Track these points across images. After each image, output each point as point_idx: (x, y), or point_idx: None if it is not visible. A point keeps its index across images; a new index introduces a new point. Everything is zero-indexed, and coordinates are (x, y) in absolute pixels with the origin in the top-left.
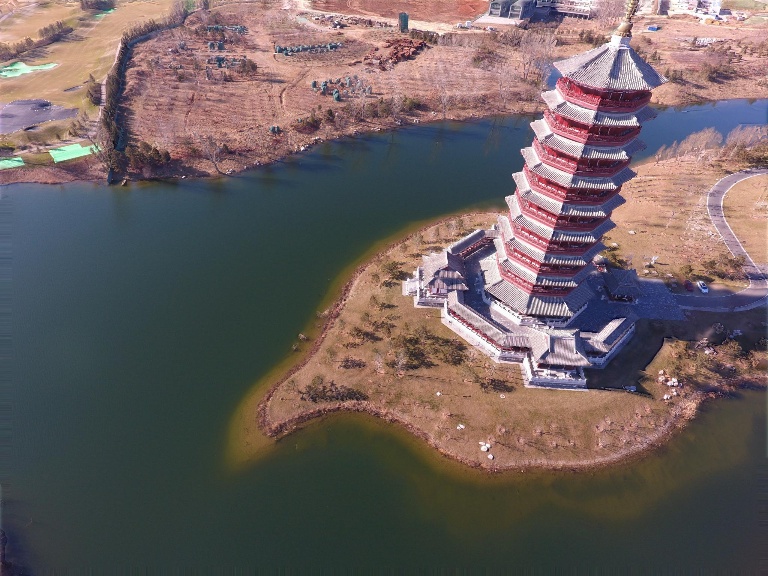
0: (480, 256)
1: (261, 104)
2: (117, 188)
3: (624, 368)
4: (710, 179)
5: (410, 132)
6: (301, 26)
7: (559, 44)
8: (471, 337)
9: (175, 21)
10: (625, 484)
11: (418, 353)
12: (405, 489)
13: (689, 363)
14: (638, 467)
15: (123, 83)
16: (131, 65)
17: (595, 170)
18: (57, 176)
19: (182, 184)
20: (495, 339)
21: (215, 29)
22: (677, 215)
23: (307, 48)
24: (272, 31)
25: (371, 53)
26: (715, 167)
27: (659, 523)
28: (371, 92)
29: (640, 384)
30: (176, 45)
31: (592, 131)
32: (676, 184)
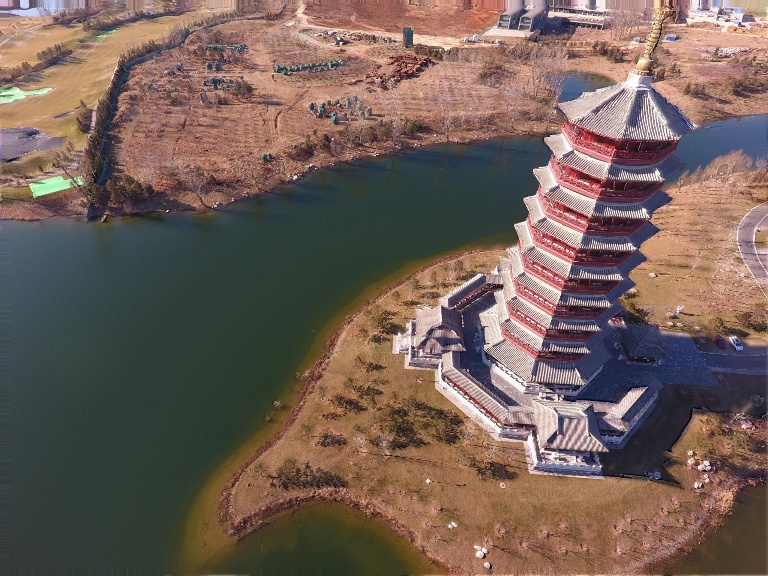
0: (481, 305)
1: (255, 129)
2: (96, 224)
3: (646, 448)
4: (739, 209)
5: (411, 157)
6: (303, 43)
7: (571, 57)
8: (468, 408)
9: (175, 41)
10: None
11: (407, 427)
12: None
13: (723, 440)
14: None
15: (114, 108)
16: (125, 89)
17: (609, 229)
18: (35, 212)
19: (165, 219)
20: (495, 414)
21: (214, 48)
22: (703, 253)
23: (307, 67)
24: (273, 49)
25: (373, 71)
26: (745, 195)
27: None
28: (371, 114)
29: (665, 469)
30: (173, 66)
31: (605, 185)
32: (701, 215)
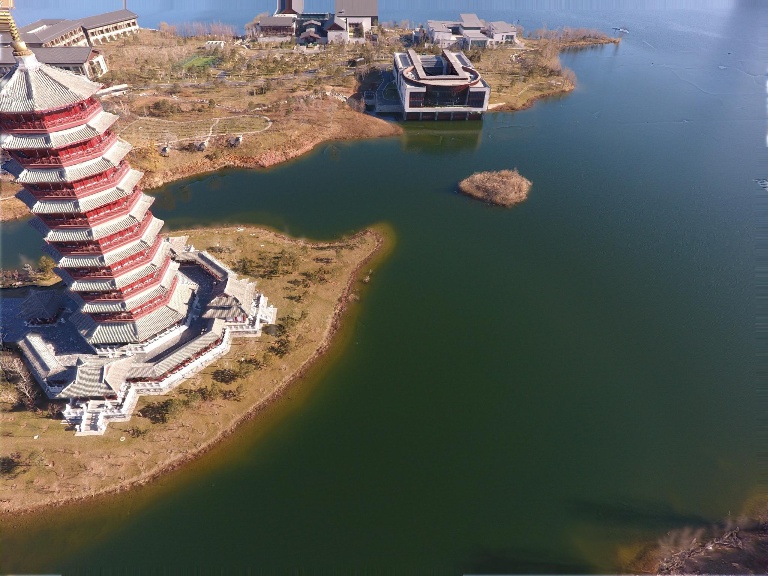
0: None
1: None
2: None
3: None
4: None
5: None
6: None
7: None
8: None
9: None
10: (165, 229)
11: None
12: None
13: None
14: None
15: None
16: None
17: None
18: None
19: (686, 518)
20: None
21: None
22: None
23: None
24: None
25: None
26: None
27: None
28: None
29: None
30: None
31: None
32: None
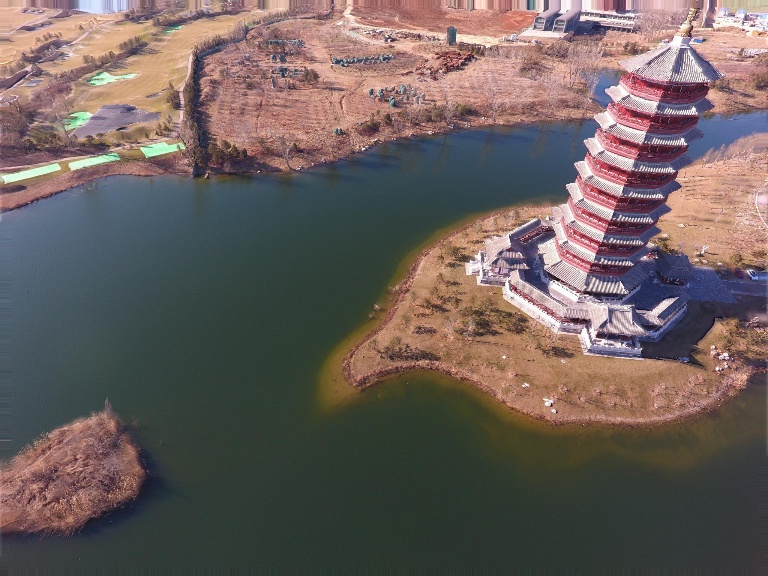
0: (537, 243)
1: (323, 109)
2: (201, 181)
3: (677, 342)
4: (759, 180)
5: (462, 135)
6: (354, 40)
7: (603, 56)
8: (532, 311)
9: (238, 36)
10: (680, 440)
11: (484, 323)
12: (477, 435)
13: (740, 341)
14: (692, 427)
15: (198, 90)
16: (203, 75)
17: (655, 156)
18: (148, 169)
19: (258, 178)
20: (556, 311)
21: None
22: (726, 211)
23: (362, 60)
24: (327, 44)
25: (422, 64)
26: (764, 169)
27: (713, 474)
28: (424, 99)
29: (693, 356)
30: (241, 57)
31: (653, 120)
32: (724, 184)
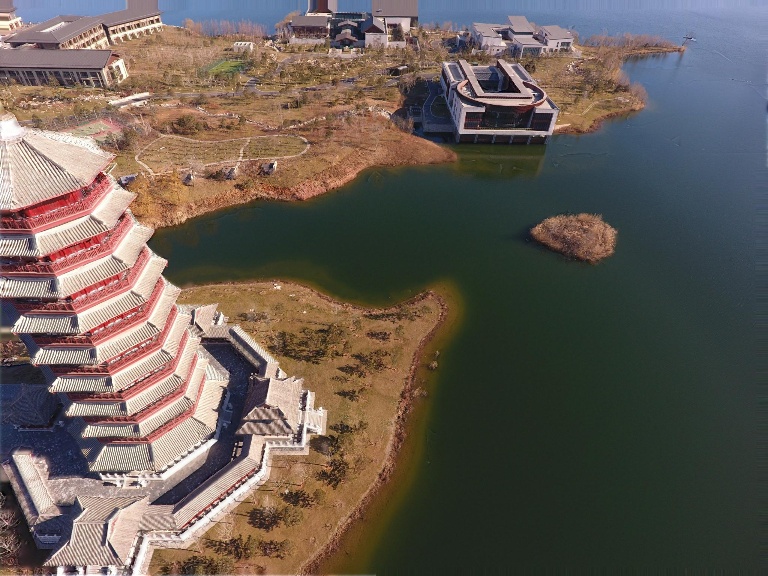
0: (198, 484)
1: None
2: None
3: None
4: None
5: None
6: None
7: None
8: None
9: None
10: None
11: None
12: None
13: None
14: None
15: None
16: None
17: None
18: None
19: None
20: None
21: None
22: None
23: None
24: None
25: None
26: None
27: None
28: None
29: None
30: None
31: None
32: None
